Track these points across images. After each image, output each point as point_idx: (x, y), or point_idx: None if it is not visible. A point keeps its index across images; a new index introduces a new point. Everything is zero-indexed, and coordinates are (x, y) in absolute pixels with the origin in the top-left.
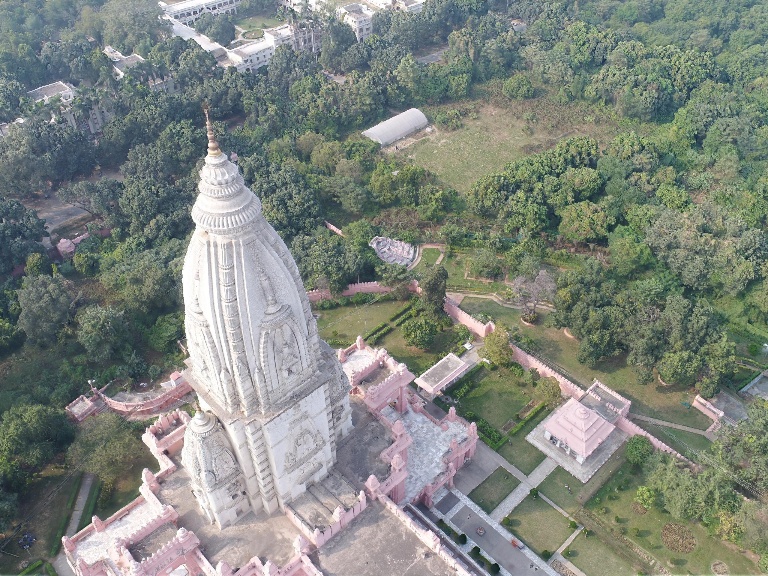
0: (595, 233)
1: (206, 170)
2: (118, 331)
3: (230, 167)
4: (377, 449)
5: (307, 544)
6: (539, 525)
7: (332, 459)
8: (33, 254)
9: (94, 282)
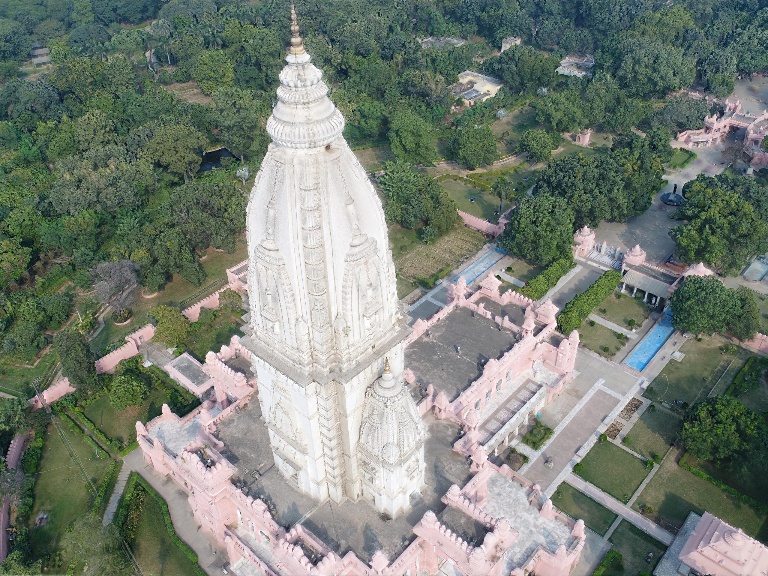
0: (26, 255)
1: (309, 71)
2: None
3: None
4: None
5: None
6: None
7: None
8: None
9: None
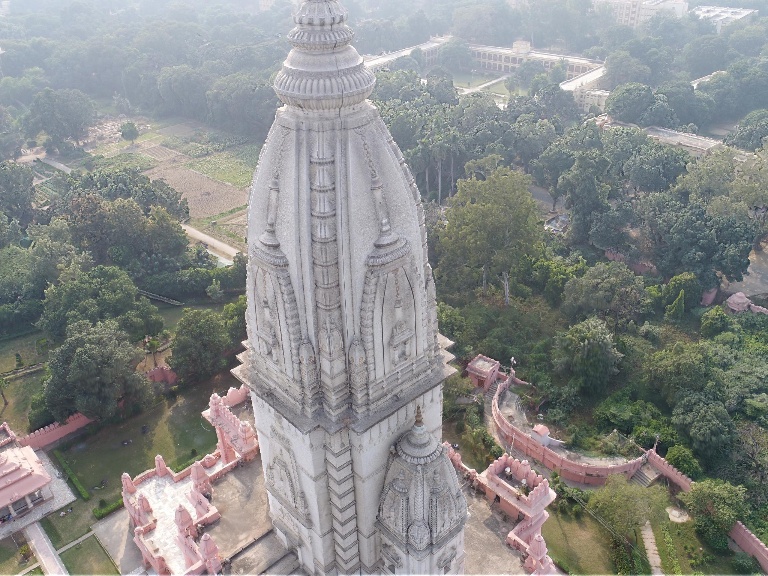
0: None
1: None
2: (589, 358)
3: (315, 6)
4: None
5: (206, 555)
6: None
7: (323, 568)
8: (691, 273)
9: (694, 340)
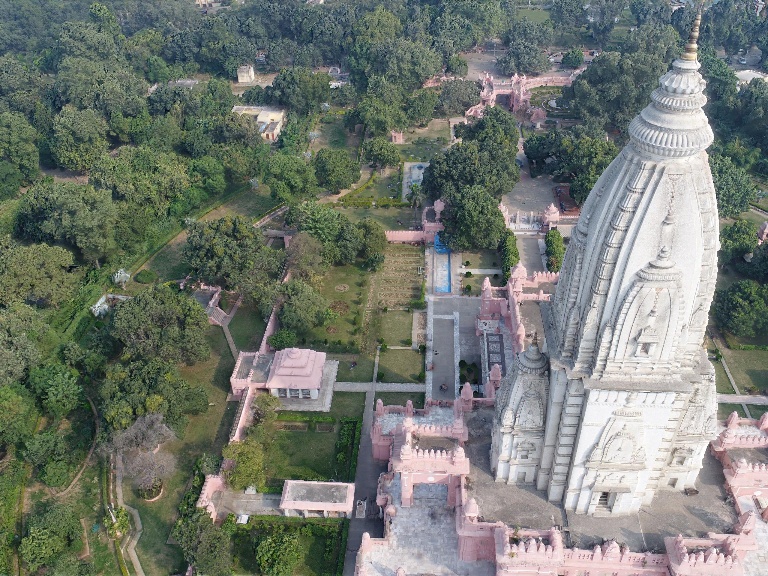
0: None
1: None
2: None
3: None
4: (493, 412)
5: None
6: (402, 366)
7: None
8: None
9: None
